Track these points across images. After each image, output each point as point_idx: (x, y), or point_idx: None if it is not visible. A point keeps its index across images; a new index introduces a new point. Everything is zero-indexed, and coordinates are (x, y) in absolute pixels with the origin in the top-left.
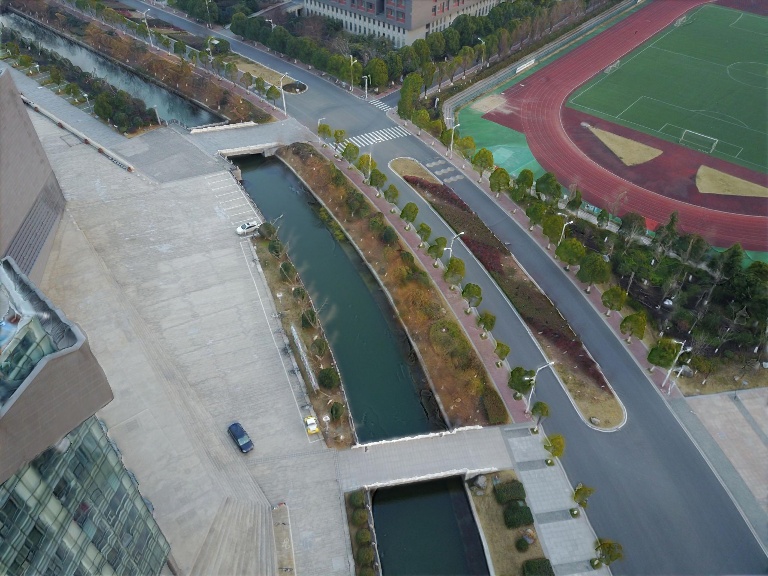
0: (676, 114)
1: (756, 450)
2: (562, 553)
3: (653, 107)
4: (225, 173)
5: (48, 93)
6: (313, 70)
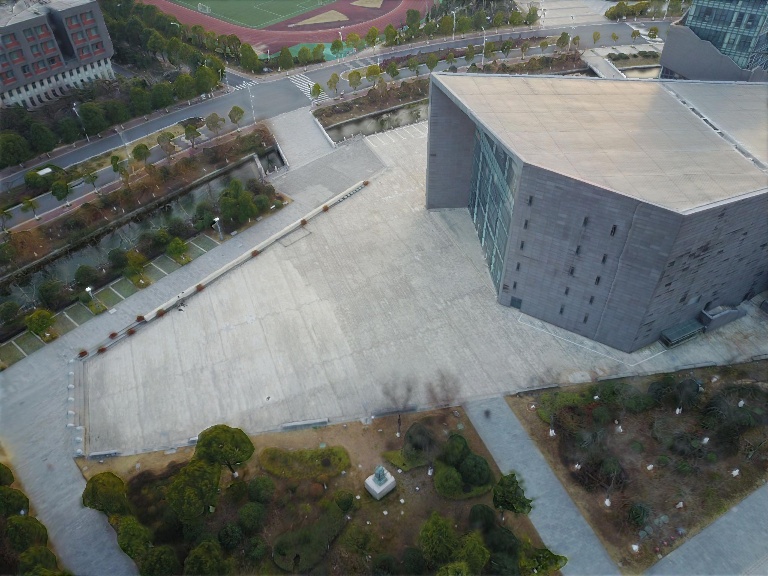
0: (285, 1)
1: (565, 19)
2: (633, 51)
3: (272, 6)
4: (368, 139)
5: (139, 296)
6: (151, 117)
